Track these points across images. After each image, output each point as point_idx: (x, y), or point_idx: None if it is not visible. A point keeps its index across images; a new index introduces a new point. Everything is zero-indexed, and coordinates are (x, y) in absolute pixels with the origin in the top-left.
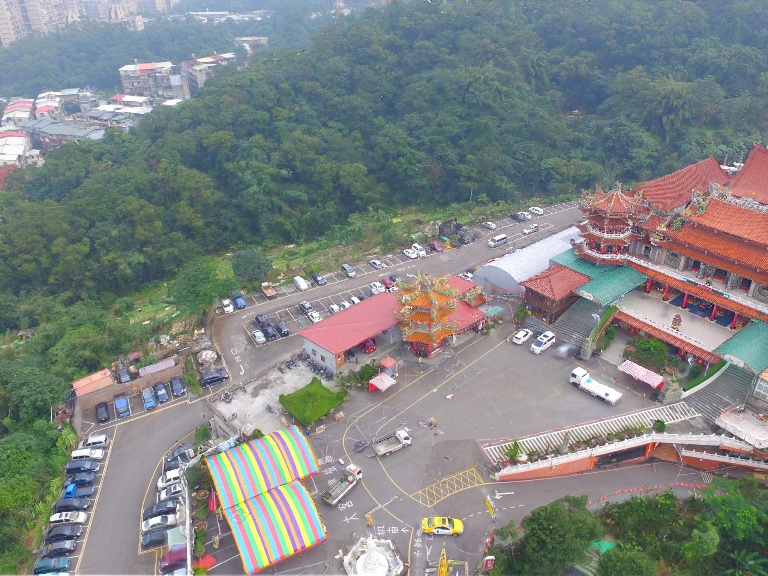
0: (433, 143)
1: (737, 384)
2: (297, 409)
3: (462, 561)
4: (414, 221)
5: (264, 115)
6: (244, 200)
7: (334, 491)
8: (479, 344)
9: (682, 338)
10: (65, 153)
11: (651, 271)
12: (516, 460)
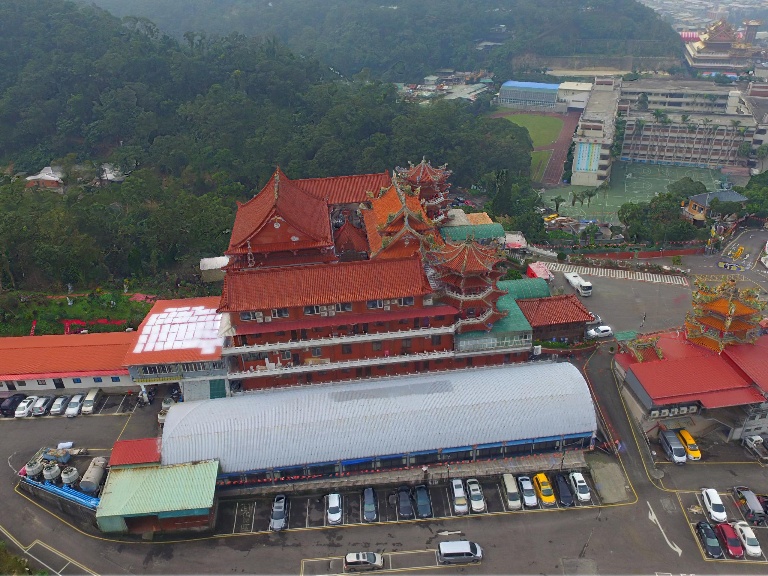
0: None
1: None
2: None
3: None
4: None
5: None
6: None
7: None
8: None
9: None
10: None
11: None
12: None
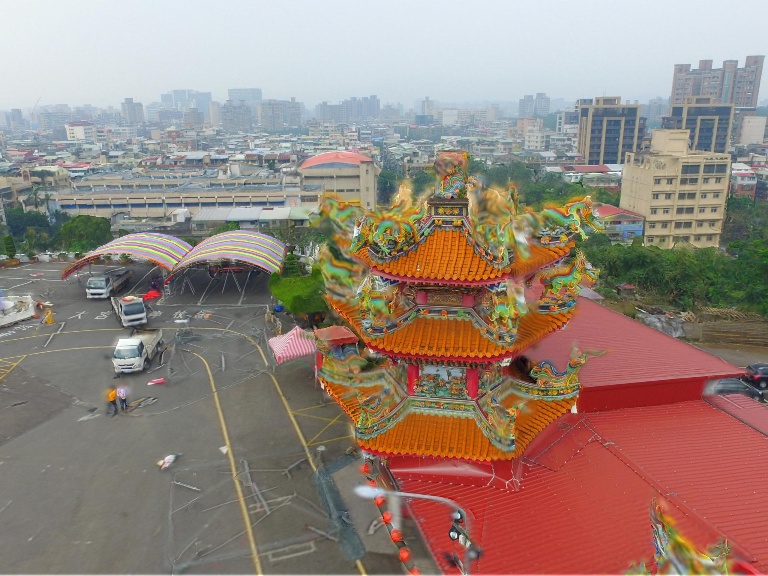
0: None
1: None
2: None
3: None
4: None
5: None
6: None
7: None
8: None
9: None
10: None
11: None
12: None
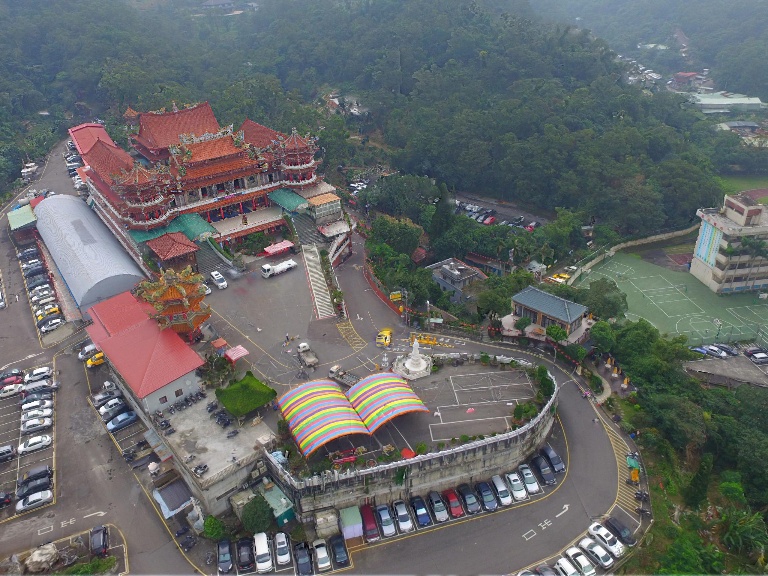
0: None
1: (303, 222)
2: (256, 401)
3: (410, 334)
4: None
5: None
6: None
7: (352, 381)
8: None
9: (257, 225)
10: None
11: (194, 209)
12: (339, 303)
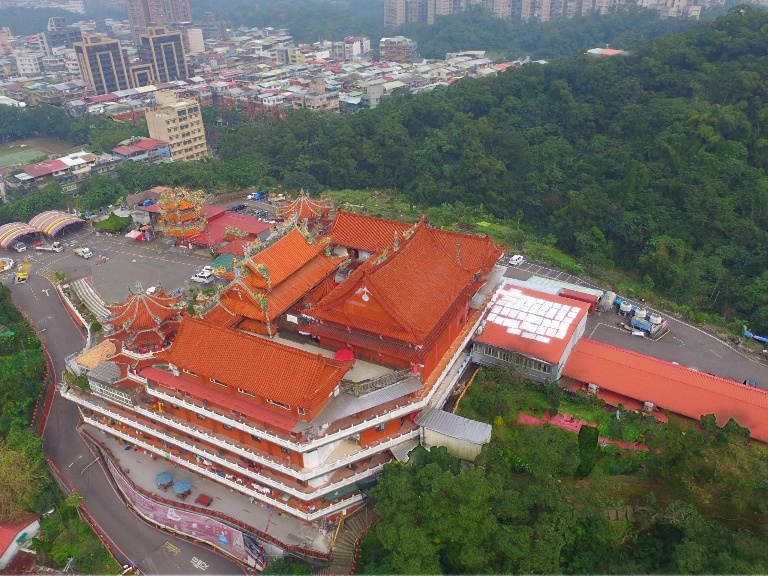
0: (580, 170)
1: None
2: None
3: None
4: (467, 224)
5: (487, 98)
6: (404, 156)
7: None
8: (201, 260)
9: None
10: (395, 94)
11: None
12: None
